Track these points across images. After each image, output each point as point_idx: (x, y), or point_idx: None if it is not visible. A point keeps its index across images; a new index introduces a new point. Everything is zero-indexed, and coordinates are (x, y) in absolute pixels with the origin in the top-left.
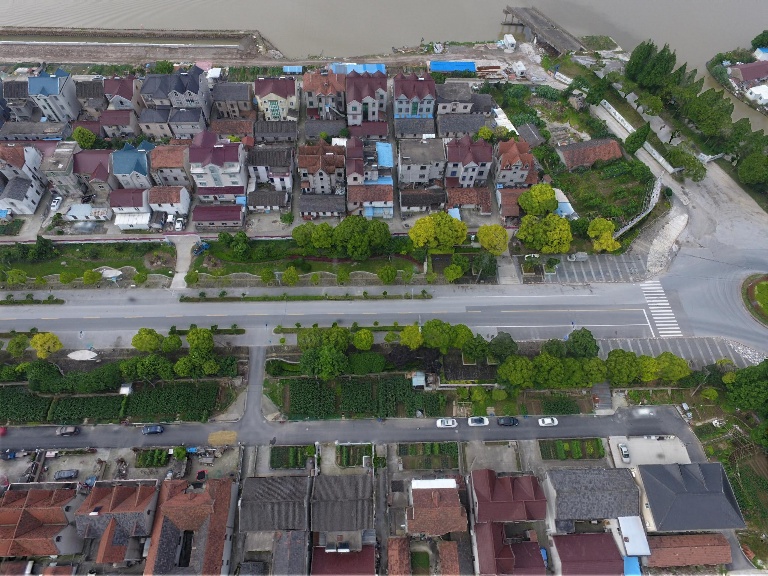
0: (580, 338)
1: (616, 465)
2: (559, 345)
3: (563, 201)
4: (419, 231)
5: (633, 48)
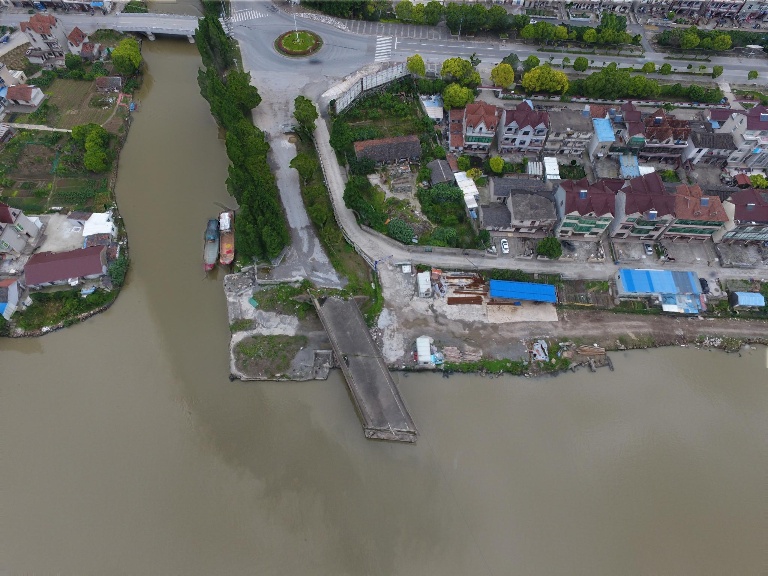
0: (460, 15)
1: (443, 4)
2: (470, 20)
3: (431, 108)
4: None
5: (201, 355)
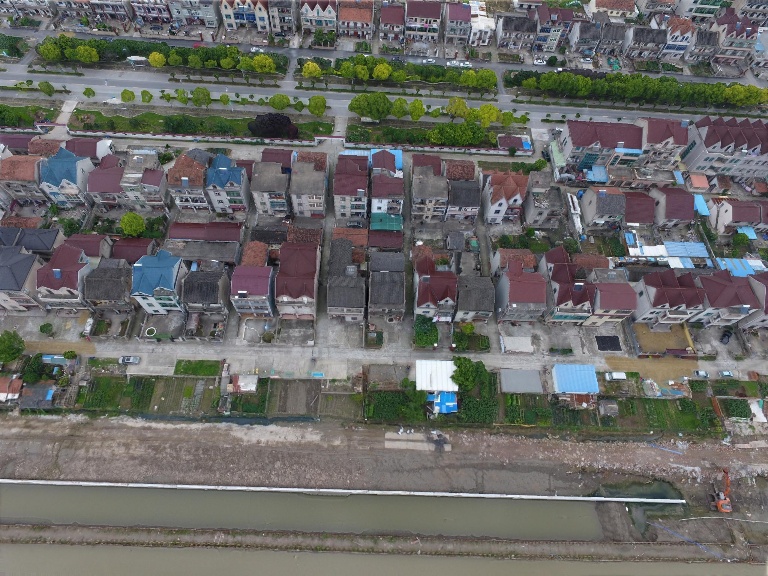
0: None
1: None
2: None
3: None
4: None
5: None
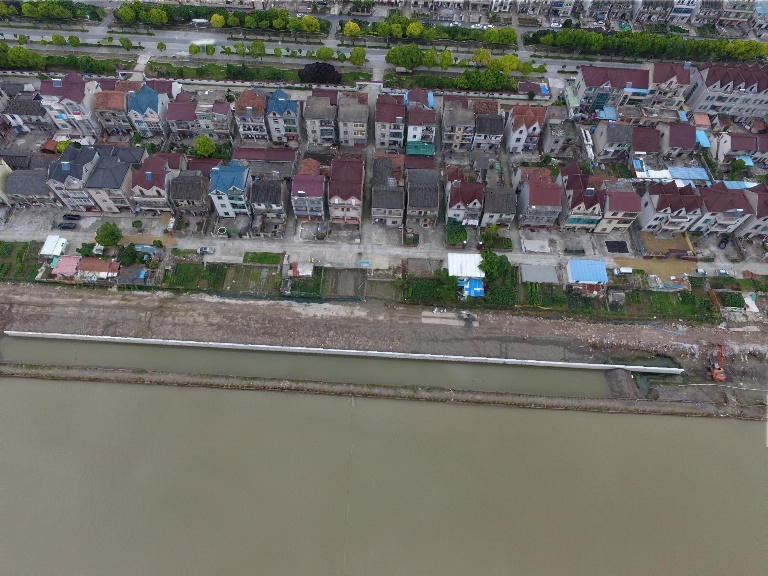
0: None
1: None
2: None
3: None
4: None
5: None
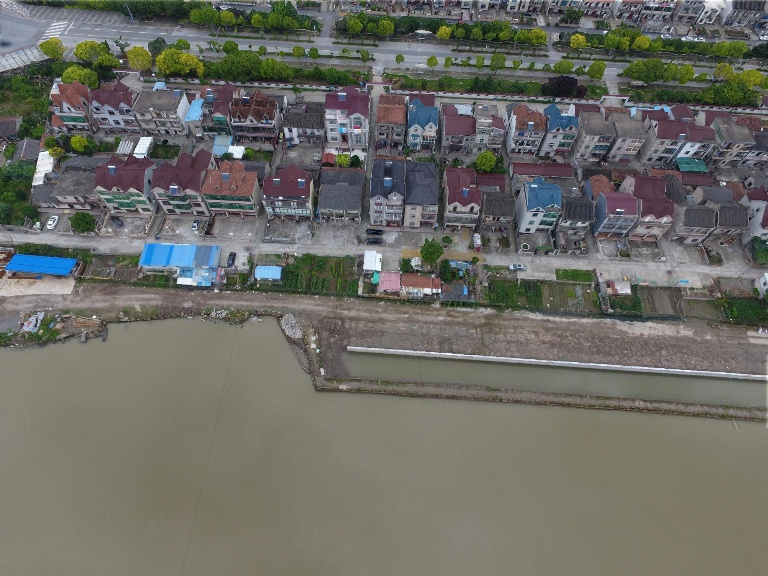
0: (126, 0)
1: None
2: (141, 5)
3: (56, 89)
4: (195, 56)
5: None
